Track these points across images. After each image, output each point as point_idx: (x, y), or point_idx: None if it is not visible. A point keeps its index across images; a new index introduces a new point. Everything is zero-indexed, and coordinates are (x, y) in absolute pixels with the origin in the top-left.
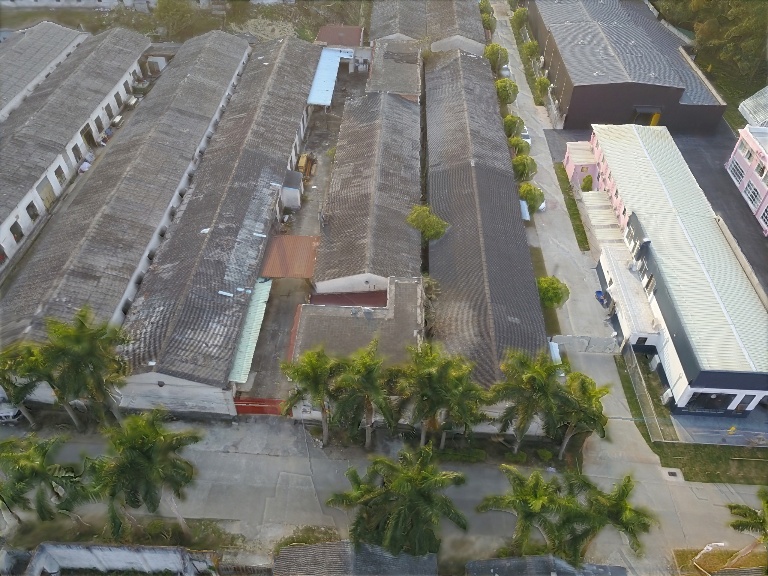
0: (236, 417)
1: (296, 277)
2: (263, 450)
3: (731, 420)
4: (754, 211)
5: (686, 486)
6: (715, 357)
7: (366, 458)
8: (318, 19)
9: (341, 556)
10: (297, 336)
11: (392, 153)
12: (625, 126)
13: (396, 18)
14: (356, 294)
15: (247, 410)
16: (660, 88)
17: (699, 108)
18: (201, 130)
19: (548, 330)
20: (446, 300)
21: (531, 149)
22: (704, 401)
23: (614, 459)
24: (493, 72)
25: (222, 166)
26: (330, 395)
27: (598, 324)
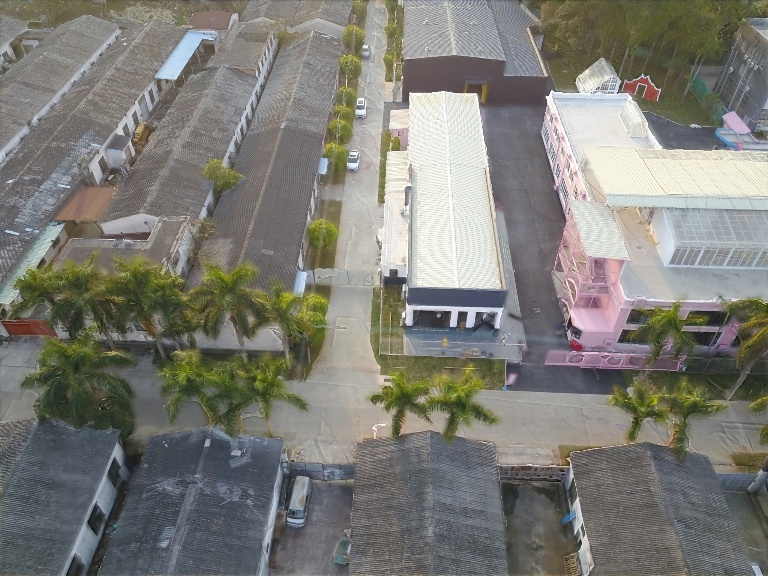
0: (8, 338)
1: (85, 220)
2: (24, 363)
3: (456, 337)
4: (552, 169)
5: None
6: (429, 278)
7: (115, 369)
8: (198, 7)
9: (27, 428)
10: (56, 263)
11: (210, 117)
12: (436, 93)
13: (266, 4)
14: (138, 234)
15: (17, 331)
16: (482, 61)
17: (522, 79)
18: (43, 100)
19: None
20: (215, 238)
21: (366, 119)
22: (429, 320)
23: (339, 369)
24: (344, 51)
25: (49, 129)
26: (53, 303)
27: (370, 263)
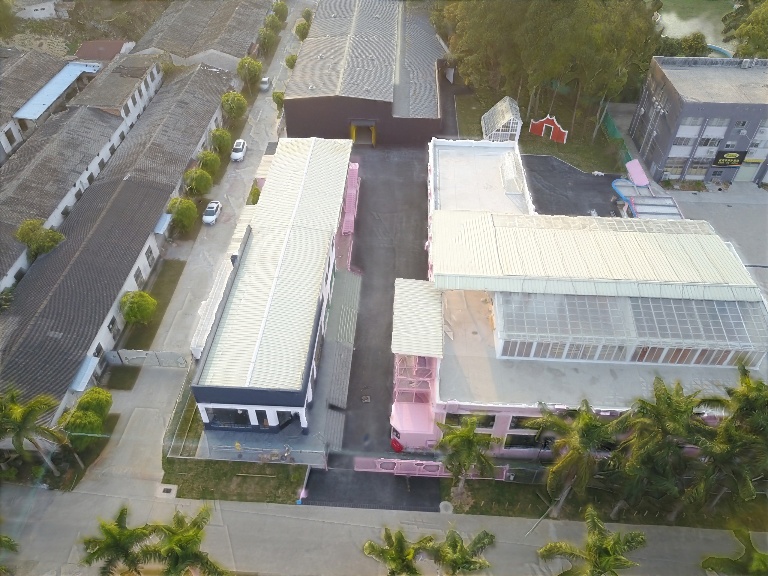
0: None
1: None
2: None
3: (260, 435)
4: None
5: (172, 503)
6: (222, 372)
7: None
8: (95, 34)
9: None
10: None
11: (48, 167)
12: (306, 139)
13: (162, 32)
14: None
15: None
16: (367, 101)
17: (413, 121)
18: None
19: (138, 344)
20: (7, 314)
21: (242, 162)
22: (227, 416)
23: (116, 475)
24: None
25: None
26: None
27: None
